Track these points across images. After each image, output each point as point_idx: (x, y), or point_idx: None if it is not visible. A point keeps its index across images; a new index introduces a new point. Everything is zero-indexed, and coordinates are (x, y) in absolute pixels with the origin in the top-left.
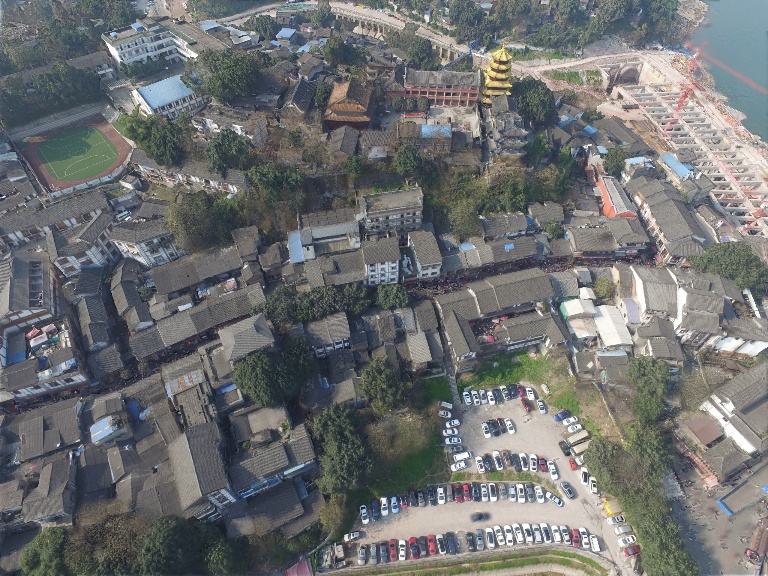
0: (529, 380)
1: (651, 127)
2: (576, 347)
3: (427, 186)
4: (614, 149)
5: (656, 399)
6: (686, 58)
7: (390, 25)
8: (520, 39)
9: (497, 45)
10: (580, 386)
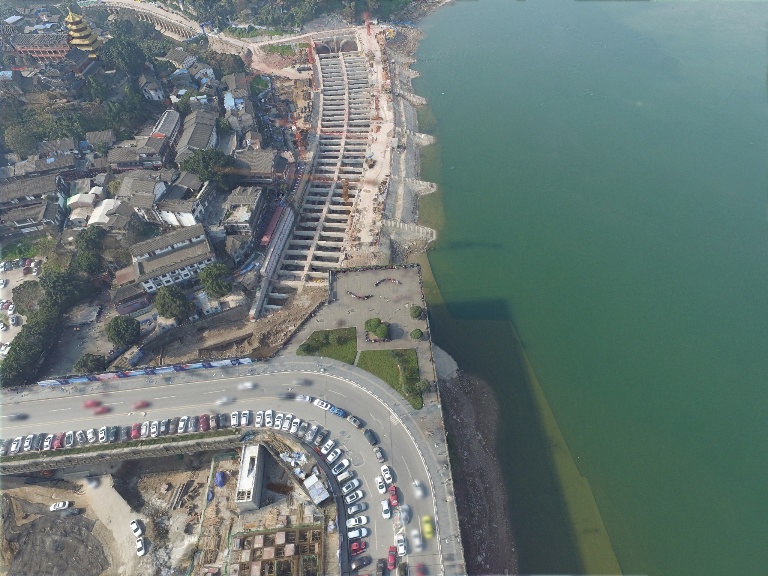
0: (41, 255)
1: (306, 83)
2: (69, 227)
3: (1, 119)
4: None
5: (88, 254)
6: (393, 30)
7: None
8: (249, 20)
9: (228, 26)
10: (60, 253)
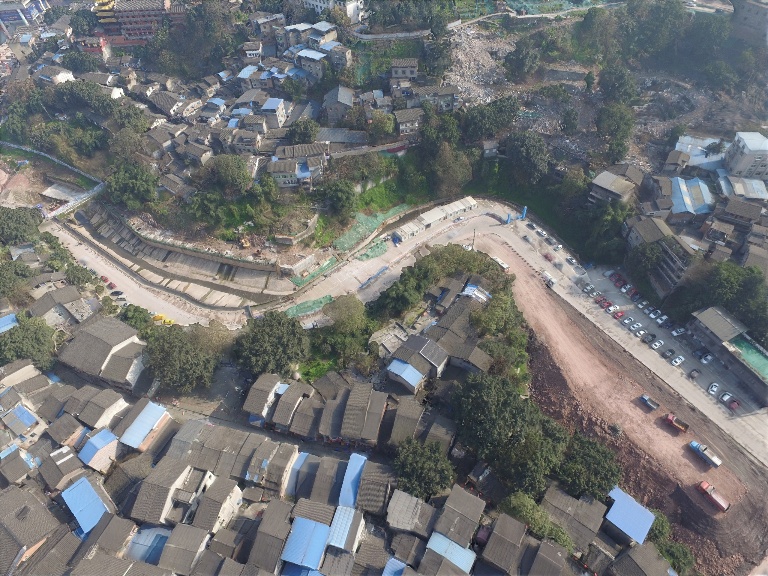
0: None
1: None
2: None
3: None
4: (54, 39)
5: None
6: None
7: (131, 269)
8: None
9: None
10: None
